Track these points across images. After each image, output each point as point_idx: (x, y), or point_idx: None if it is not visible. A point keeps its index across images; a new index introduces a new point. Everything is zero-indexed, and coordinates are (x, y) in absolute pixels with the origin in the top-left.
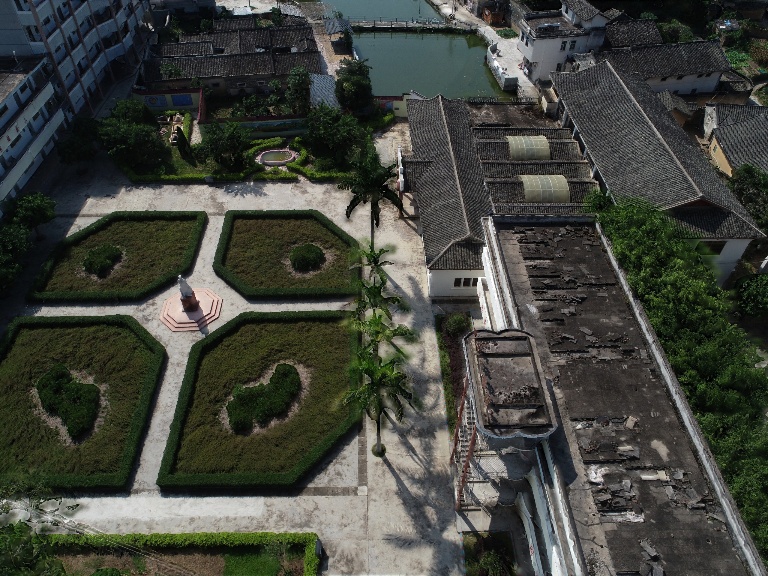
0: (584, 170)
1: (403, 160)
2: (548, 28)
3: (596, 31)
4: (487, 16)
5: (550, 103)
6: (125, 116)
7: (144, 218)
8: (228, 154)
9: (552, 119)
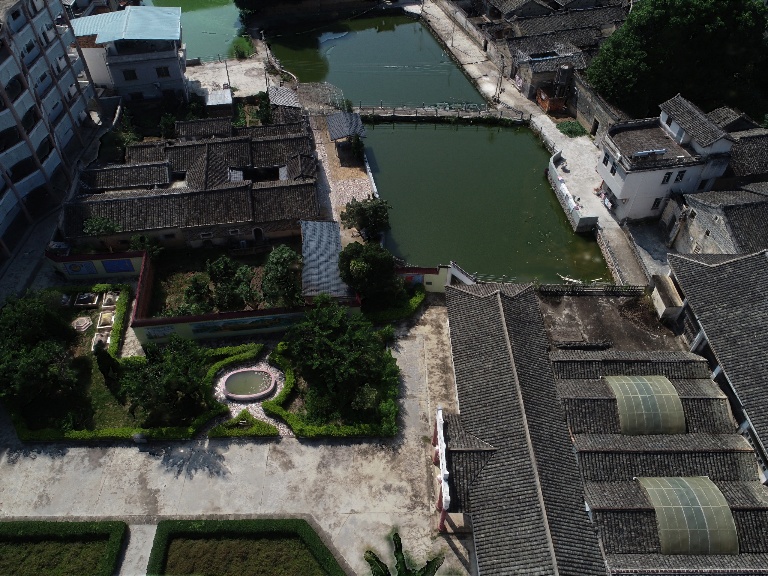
0: (748, 466)
1: (447, 443)
2: (648, 156)
3: (717, 159)
4: (543, 101)
5: (670, 307)
6: (14, 329)
7: (24, 537)
8: (168, 403)
9: (671, 330)
